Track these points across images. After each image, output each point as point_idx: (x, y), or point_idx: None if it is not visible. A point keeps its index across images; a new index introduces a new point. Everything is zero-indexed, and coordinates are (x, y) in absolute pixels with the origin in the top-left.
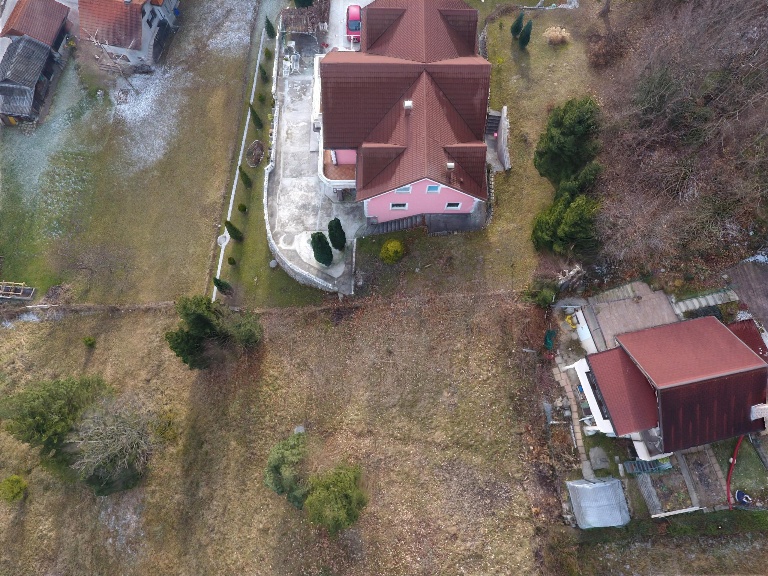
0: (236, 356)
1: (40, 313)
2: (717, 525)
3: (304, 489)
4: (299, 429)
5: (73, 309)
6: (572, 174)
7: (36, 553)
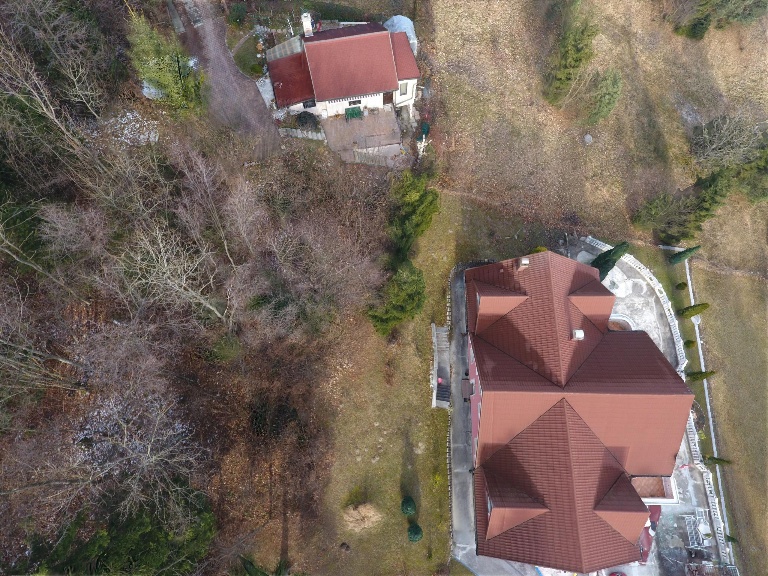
0: None
1: None
2: (337, 7)
3: None
4: (589, 140)
5: None
6: (399, 255)
7: None
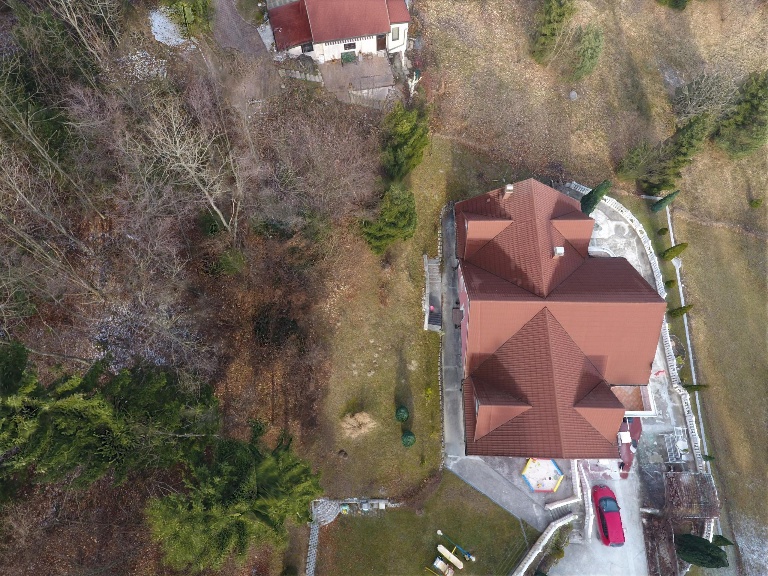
0: None
1: None
2: None
3: None
4: (574, 96)
5: None
6: None
7: None
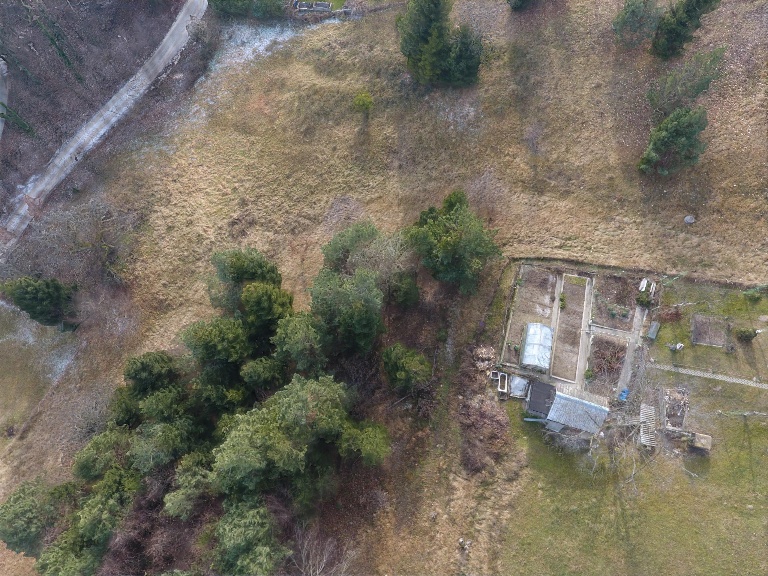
0: (541, 3)
1: (342, 16)
2: None
3: (662, 11)
4: None
5: (373, 9)
6: None
7: (382, 150)
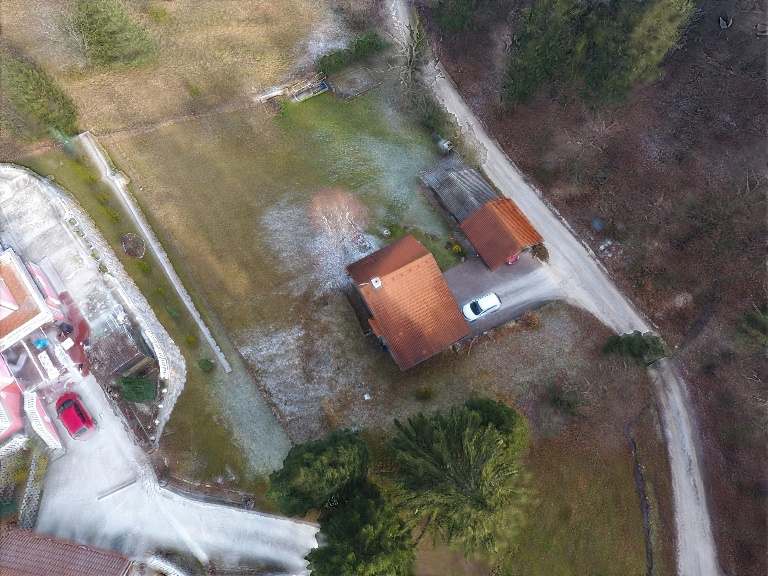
0: None
1: None
2: None
3: None
4: None
5: (246, 102)
6: None
7: (143, 8)
